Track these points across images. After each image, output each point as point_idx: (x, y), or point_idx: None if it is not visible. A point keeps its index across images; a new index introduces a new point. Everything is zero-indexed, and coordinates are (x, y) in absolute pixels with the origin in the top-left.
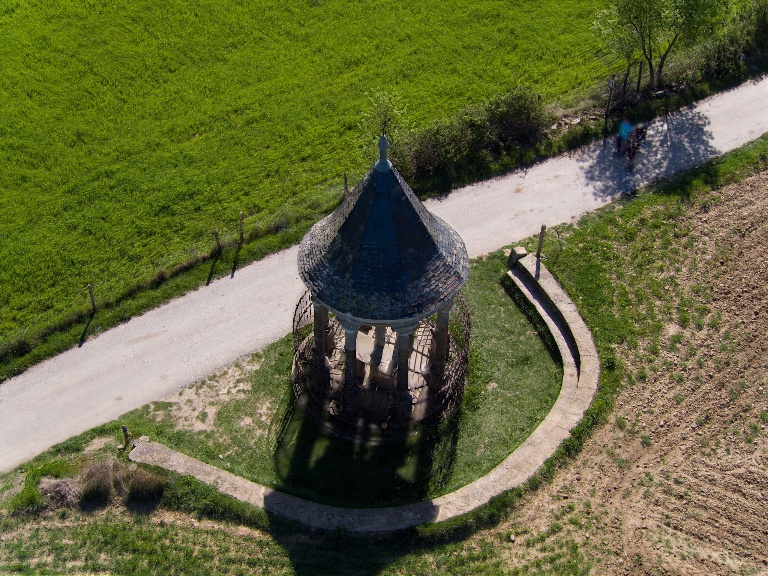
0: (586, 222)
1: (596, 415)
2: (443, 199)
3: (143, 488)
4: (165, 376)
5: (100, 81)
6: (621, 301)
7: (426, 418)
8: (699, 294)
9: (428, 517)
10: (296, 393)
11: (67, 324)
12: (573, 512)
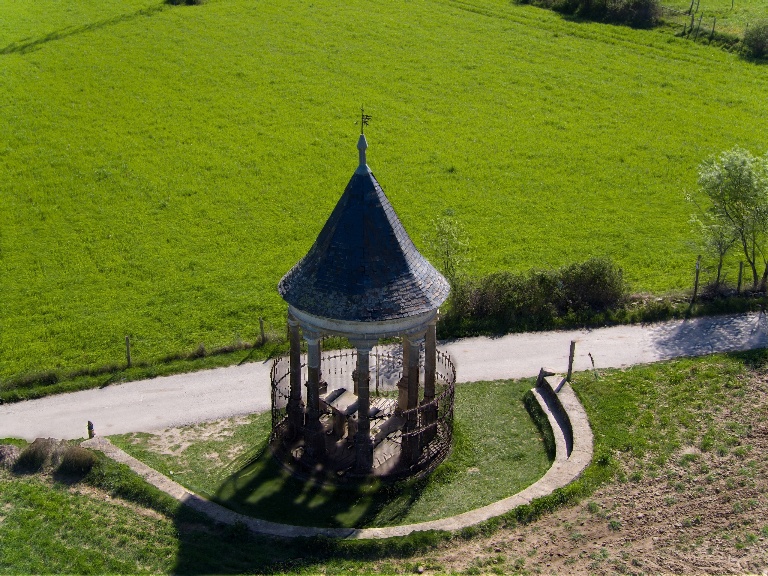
0: (635, 368)
1: (566, 494)
2: (496, 338)
3: (74, 458)
4: (161, 417)
5: (232, 239)
6: (641, 422)
7: (388, 477)
8: (733, 429)
9: (338, 535)
10: (270, 440)
11: (99, 372)
12: (501, 564)
